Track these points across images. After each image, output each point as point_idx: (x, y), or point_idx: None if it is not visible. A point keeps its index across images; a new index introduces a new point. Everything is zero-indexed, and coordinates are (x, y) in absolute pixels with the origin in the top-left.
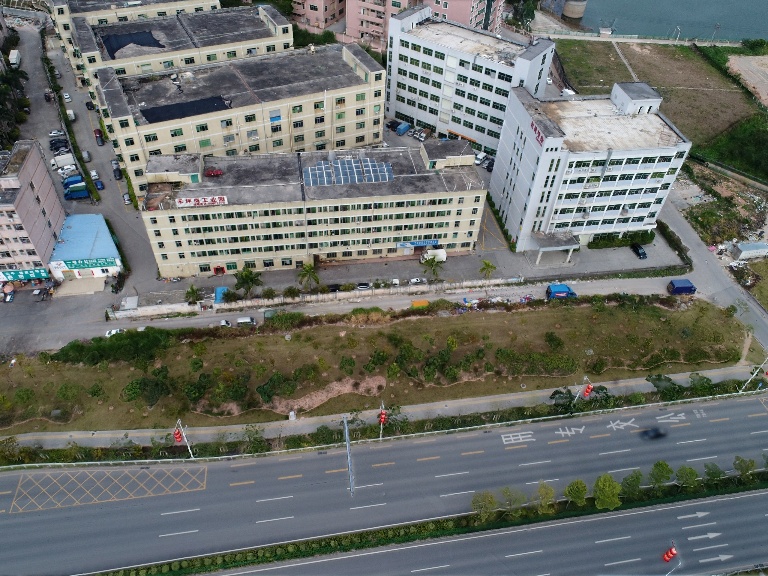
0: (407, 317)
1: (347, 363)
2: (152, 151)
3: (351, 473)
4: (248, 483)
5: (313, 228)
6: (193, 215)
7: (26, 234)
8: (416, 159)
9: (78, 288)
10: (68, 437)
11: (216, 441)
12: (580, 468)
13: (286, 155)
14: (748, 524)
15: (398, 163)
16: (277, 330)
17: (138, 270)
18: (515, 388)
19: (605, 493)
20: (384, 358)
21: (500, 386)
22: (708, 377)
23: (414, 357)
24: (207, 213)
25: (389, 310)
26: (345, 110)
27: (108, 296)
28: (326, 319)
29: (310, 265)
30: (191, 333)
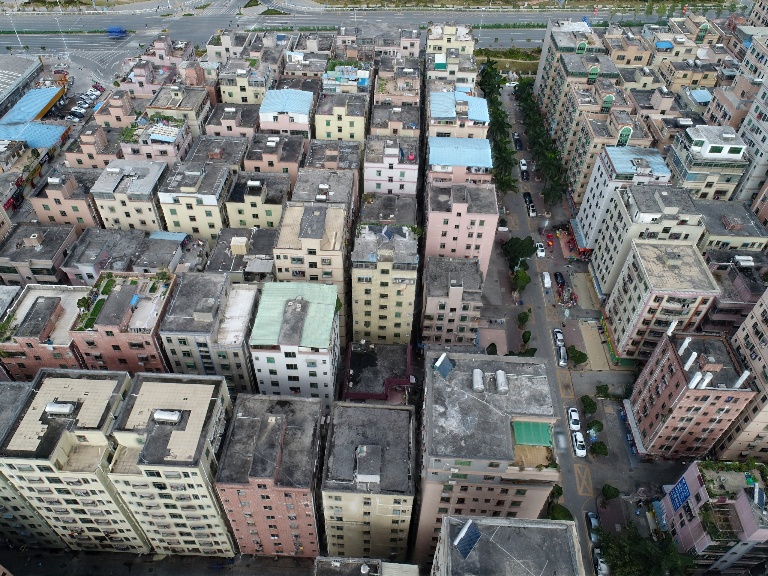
0: None
1: None
2: None
3: None
4: None
5: None
6: None
7: None
8: None
9: None
10: None
11: None
12: (650, 19)
13: None
14: None
15: None
16: None
17: None
18: None
19: (661, 8)
20: None
21: None
22: (709, 5)
23: None
24: None
25: None
26: None
27: None
28: None
29: None
30: None
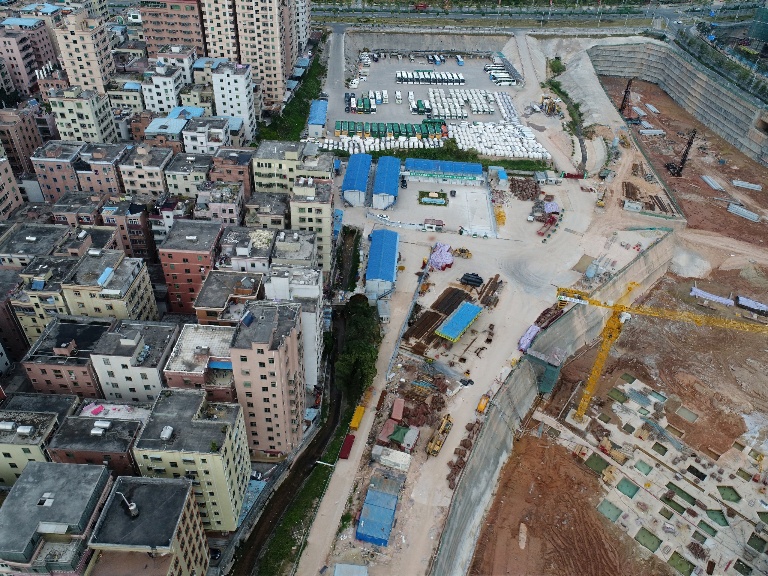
0: None
1: None
2: None
3: None
4: None
5: None
6: None
7: None
8: None
9: None
10: None
11: None
12: None
13: None
14: (317, 13)
15: None
16: None
17: None
18: None
19: None
20: None
21: None
22: None
23: None
24: None
25: None
26: None
27: None
28: None
29: None
30: None
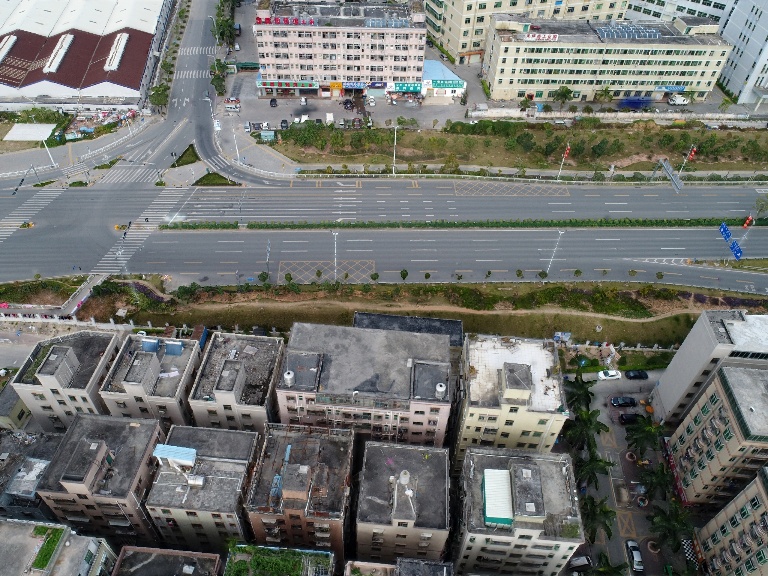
0: (671, 129)
1: (648, 139)
2: (479, 17)
3: (677, 181)
4: (596, 196)
5: (604, 67)
6: (532, 48)
7: (423, 54)
8: (672, 29)
9: (437, 101)
10: (473, 167)
11: (568, 175)
12: None
13: (579, 21)
14: None
15: (660, 30)
16: (584, 128)
17: (472, 95)
18: (759, 168)
19: None
20: (671, 140)
21: (748, 166)
22: None
23: (691, 141)
24: (541, 47)
25: (658, 124)
26: (603, 2)
27: (459, 106)
28: (615, 126)
29: (608, 87)
30: (527, 126)
